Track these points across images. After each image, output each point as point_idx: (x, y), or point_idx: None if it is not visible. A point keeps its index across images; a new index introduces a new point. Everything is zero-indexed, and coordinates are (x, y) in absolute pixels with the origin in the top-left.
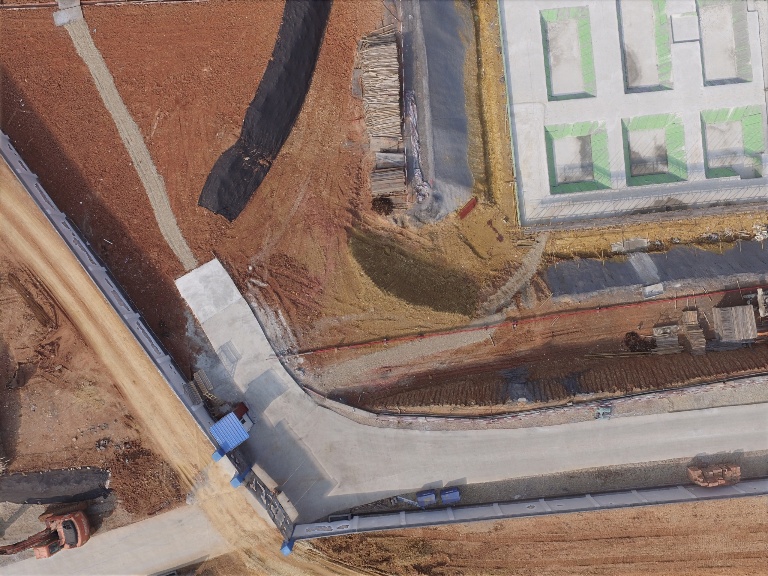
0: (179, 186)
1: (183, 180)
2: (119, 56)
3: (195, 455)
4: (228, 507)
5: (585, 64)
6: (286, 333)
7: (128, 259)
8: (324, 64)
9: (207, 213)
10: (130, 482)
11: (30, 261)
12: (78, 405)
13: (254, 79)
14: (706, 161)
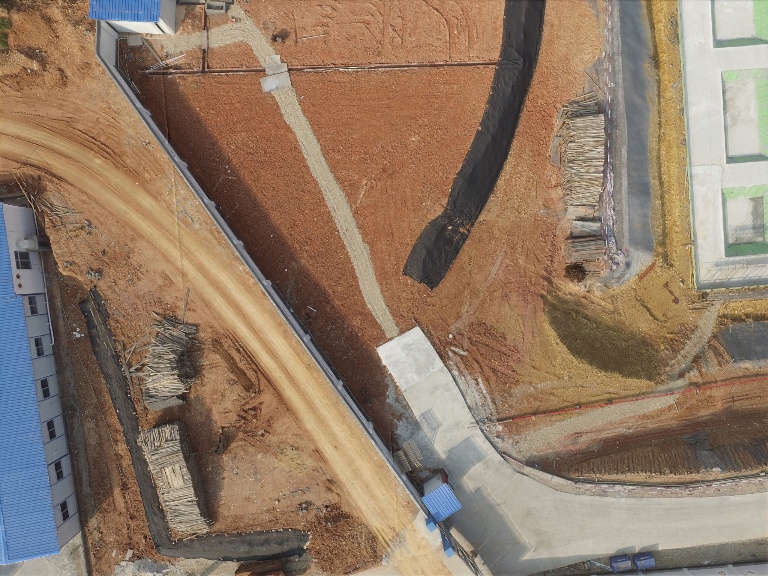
0: (384, 255)
1: (388, 249)
2: (326, 123)
3: (394, 518)
4: (424, 568)
5: (763, 126)
6: (486, 401)
7: (331, 326)
8: (523, 131)
9: (411, 282)
10: (328, 543)
11: (233, 327)
12: (281, 469)
13: (461, 149)
14: None
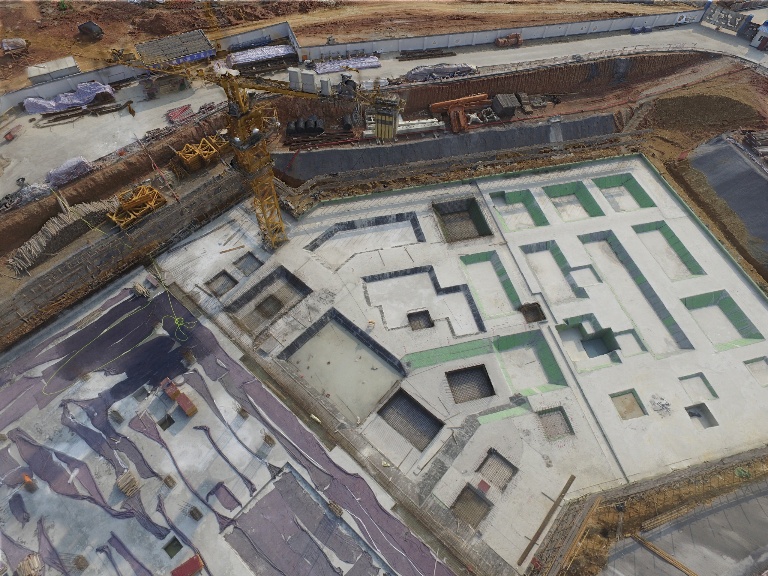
0: None
1: None
2: None
3: None
4: None
5: None
6: (763, 73)
7: None
8: None
9: None
10: None
11: None
12: None
13: None
14: (528, 204)
